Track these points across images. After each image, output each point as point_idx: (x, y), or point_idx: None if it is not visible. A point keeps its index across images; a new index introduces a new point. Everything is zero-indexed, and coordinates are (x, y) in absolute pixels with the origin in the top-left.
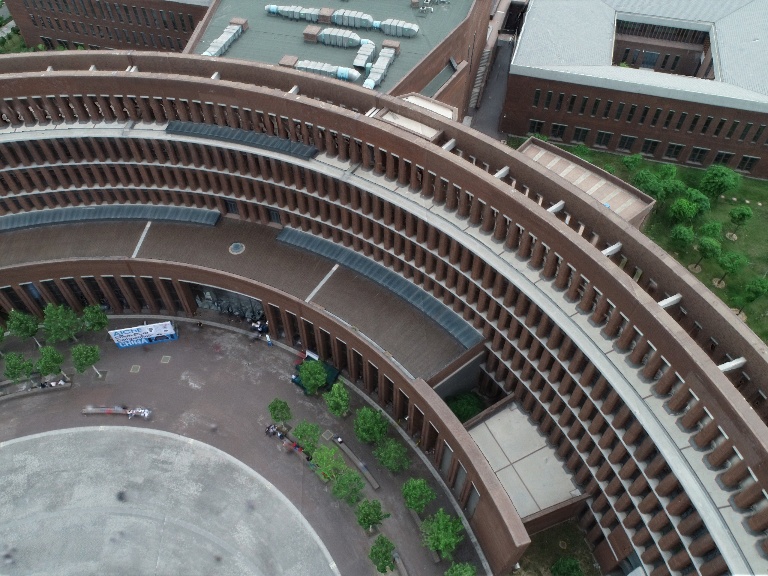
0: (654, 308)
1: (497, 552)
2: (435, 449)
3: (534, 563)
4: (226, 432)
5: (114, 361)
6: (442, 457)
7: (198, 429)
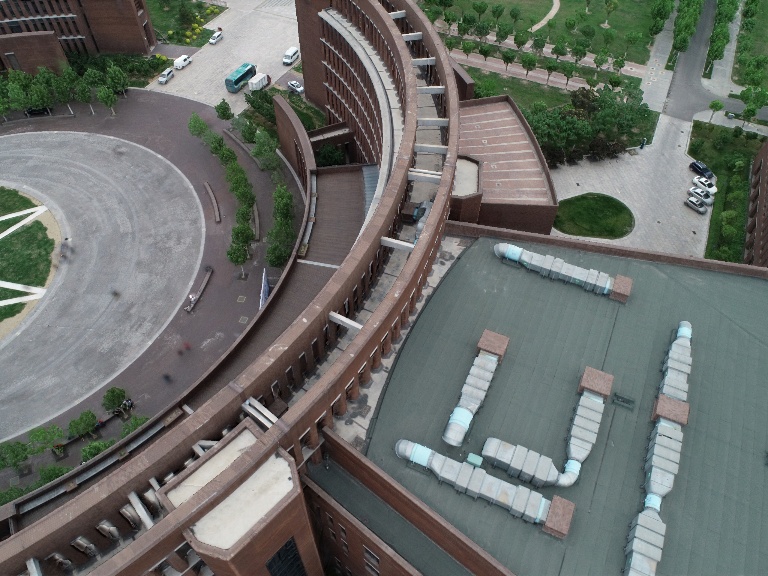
0: None
1: None
2: None
3: None
4: (146, 368)
5: (255, 284)
6: None
7: (159, 347)
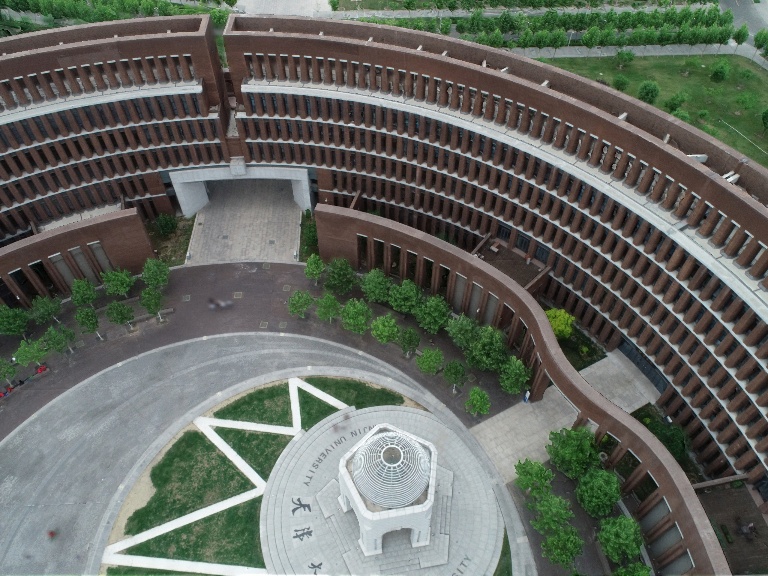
0: (7, 57)
1: (141, 250)
2: (54, 281)
3: (158, 249)
4: None
5: None
6: (62, 277)
7: None
